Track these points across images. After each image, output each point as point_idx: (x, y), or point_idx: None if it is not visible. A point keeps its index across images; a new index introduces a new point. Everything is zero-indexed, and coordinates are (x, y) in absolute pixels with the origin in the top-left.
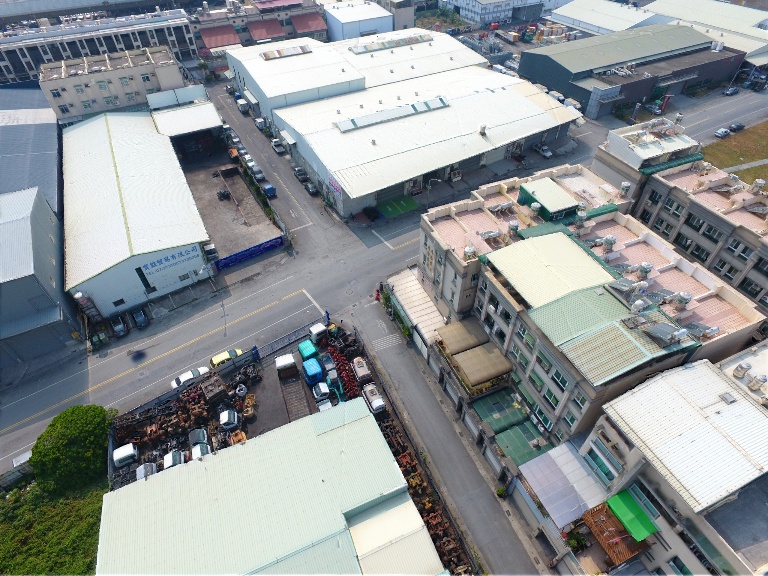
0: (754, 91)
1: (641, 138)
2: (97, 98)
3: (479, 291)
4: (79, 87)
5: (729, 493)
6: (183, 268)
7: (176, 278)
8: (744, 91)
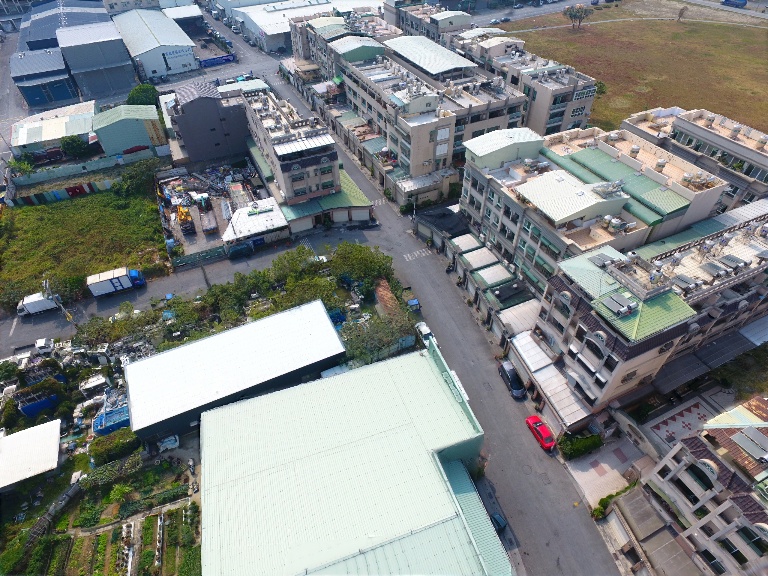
0: (533, 7)
1: None
2: (130, 1)
3: (309, 43)
4: None
5: (351, 50)
6: (184, 60)
7: (181, 65)
8: (527, 7)
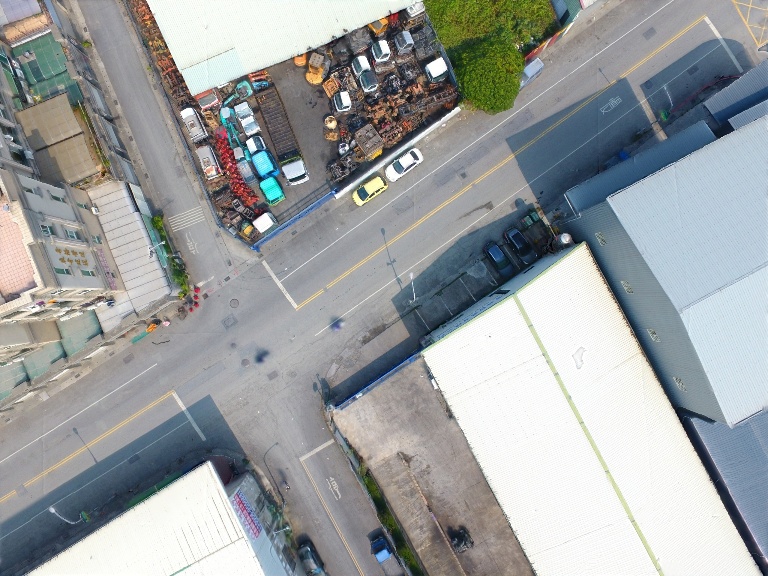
0: None
1: None
2: None
3: None
4: None
5: None
6: None
7: None
8: None
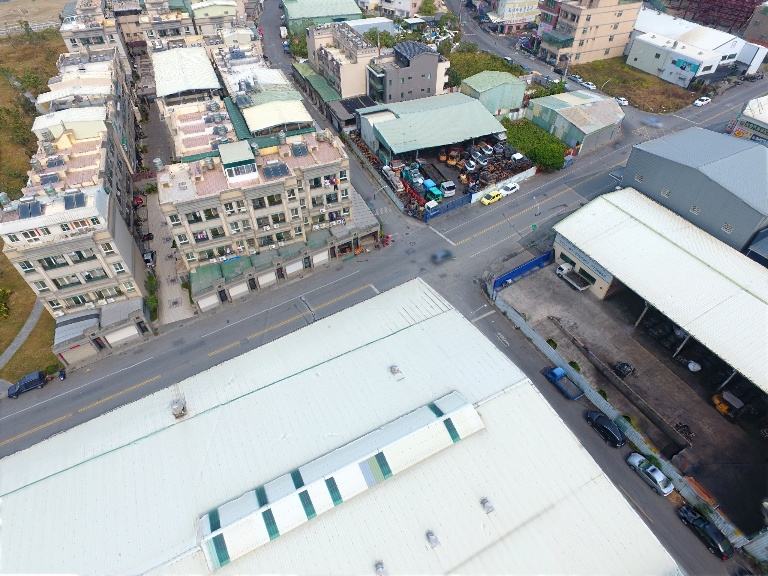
0: None
1: None
2: None
3: None
4: None
5: None
6: None
7: None
8: None
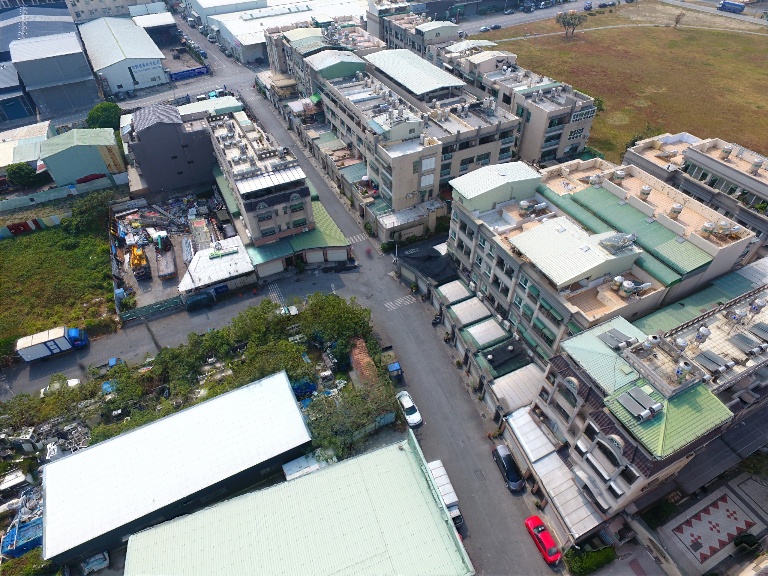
0: (525, 12)
1: (382, 2)
2: (98, 8)
3: None
4: (87, 0)
5: (328, 66)
6: (152, 73)
7: (149, 79)
8: None
